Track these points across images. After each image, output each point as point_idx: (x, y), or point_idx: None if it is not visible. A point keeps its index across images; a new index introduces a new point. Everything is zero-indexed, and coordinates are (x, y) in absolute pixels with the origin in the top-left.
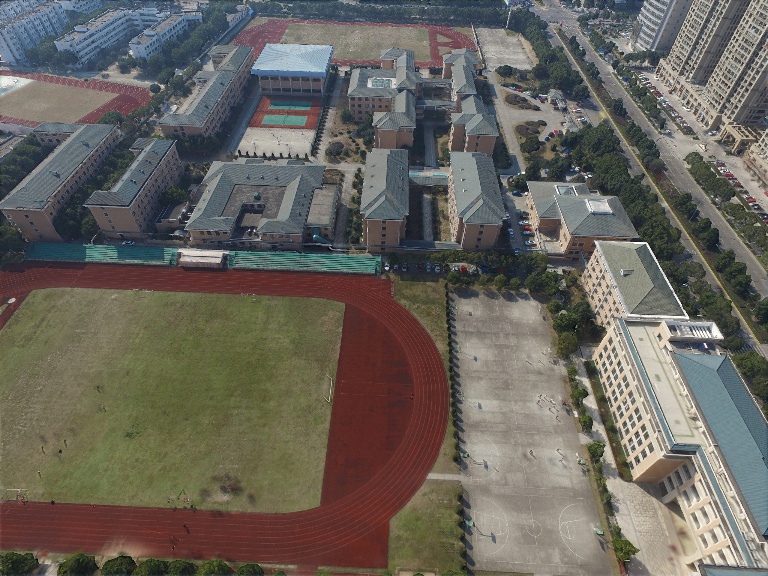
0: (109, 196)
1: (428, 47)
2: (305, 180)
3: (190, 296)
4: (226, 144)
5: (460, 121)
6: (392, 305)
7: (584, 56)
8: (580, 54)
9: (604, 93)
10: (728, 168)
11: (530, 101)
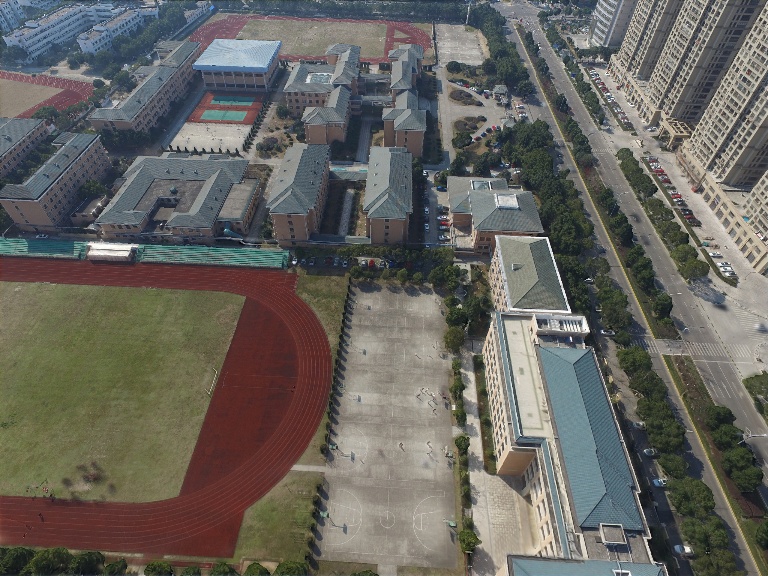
0: (18, 189)
1: (383, 43)
2: (224, 174)
3: (93, 289)
4: (160, 139)
5: (390, 116)
6: (292, 299)
7: (539, 52)
8: (533, 50)
9: (551, 89)
10: (660, 164)
11: (475, 97)
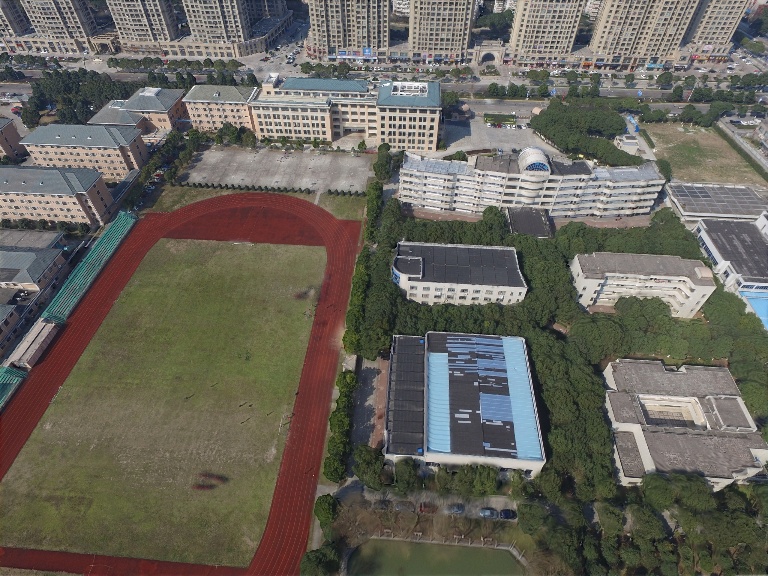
0: None
1: None
2: None
3: (91, 349)
4: None
5: None
6: (177, 213)
7: None
8: None
9: None
10: None
11: None
